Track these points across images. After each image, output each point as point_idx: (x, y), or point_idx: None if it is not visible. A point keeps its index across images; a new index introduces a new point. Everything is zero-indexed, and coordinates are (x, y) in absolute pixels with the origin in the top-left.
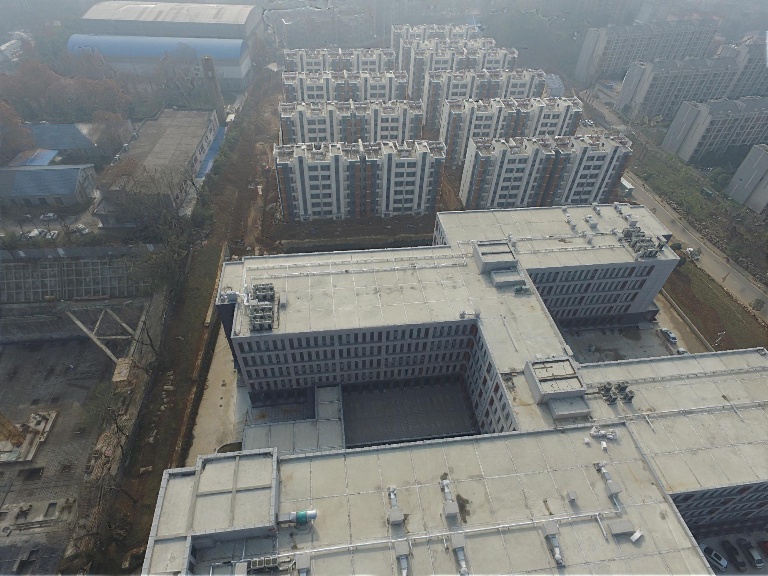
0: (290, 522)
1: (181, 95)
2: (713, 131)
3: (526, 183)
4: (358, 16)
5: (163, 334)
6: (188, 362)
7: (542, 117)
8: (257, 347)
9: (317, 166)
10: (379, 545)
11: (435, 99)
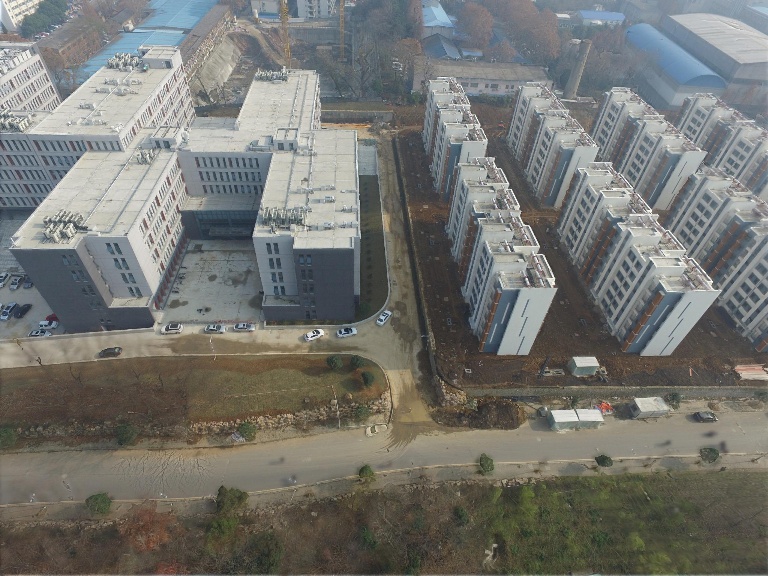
0: None
1: None
2: None
3: None
4: None
5: None
6: None
7: (625, 250)
8: None
9: None
10: None
11: (682, 197)
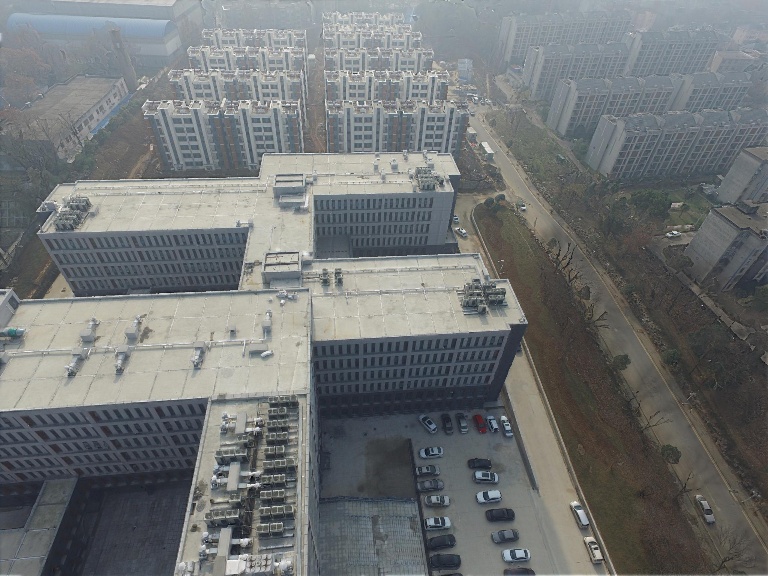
0: (5, 336)
1: (110, 69)
2: (583, 106)
3: (376, 141)
4: (295, 4)
5: (19, 250)
6: (33, 270)
7: (411, 87)
8: (65, 245)
9: (180, 119)
10: (66, 352)
11: None
